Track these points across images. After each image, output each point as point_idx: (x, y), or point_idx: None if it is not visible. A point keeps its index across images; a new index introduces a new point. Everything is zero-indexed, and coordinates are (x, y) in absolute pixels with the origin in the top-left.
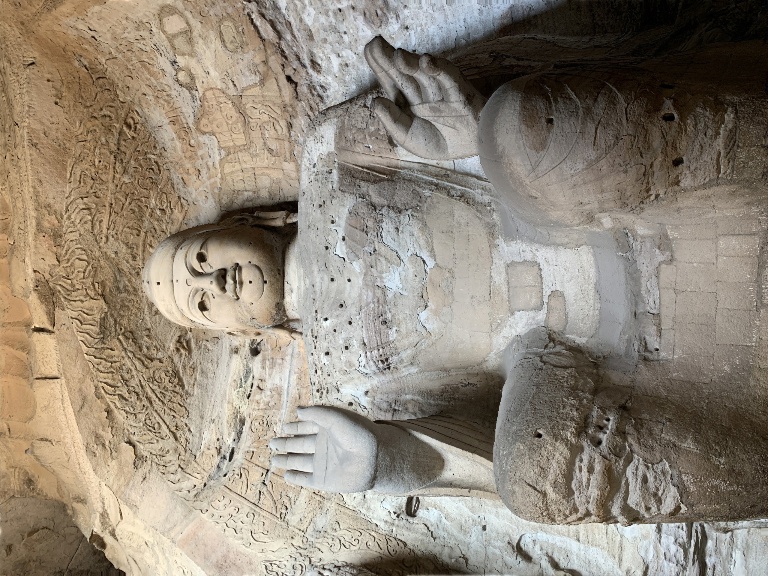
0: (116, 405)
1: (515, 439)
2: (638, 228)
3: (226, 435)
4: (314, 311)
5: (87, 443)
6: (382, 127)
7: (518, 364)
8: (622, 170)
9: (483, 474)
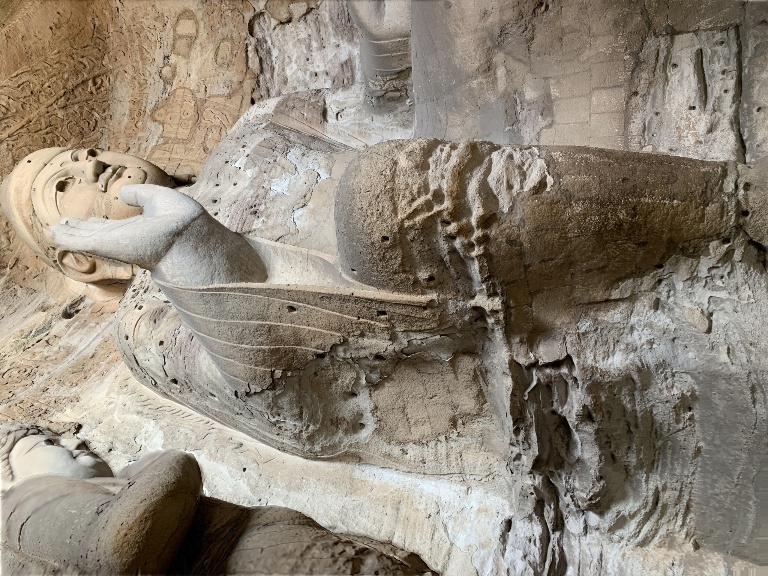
0: None
1: None
2: (526, 90)
3: None
4: None
5: None
6: (322, 100)
7: None
8: None
9: (311, 280)
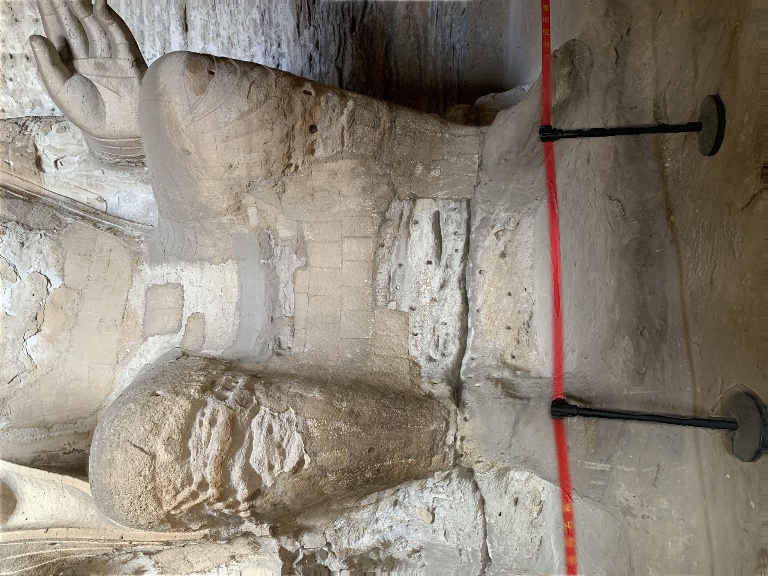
0: None
1: (126, 402)
2: (279, 228)
3: None
4: None
5: None
6: (31, 145)
7: None
8: (269, 127)
9: (72, 509)
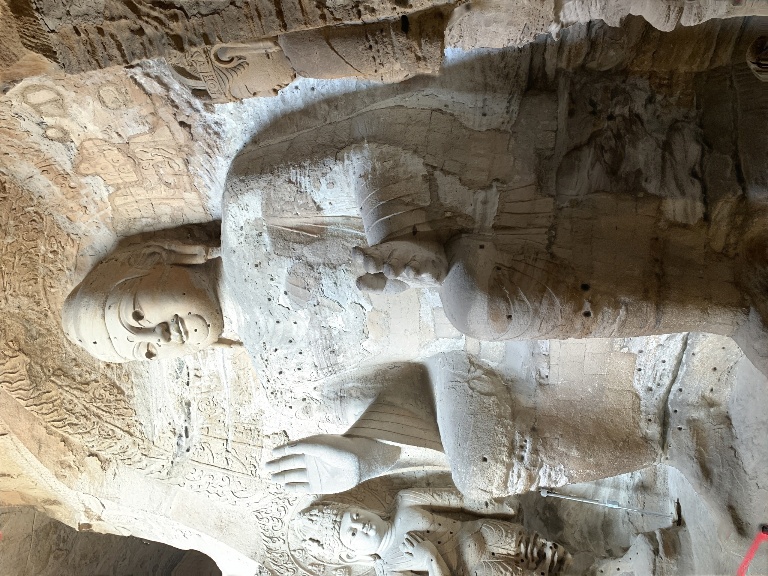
0: (69, 432)
1: (469, 463)
2: None
3: (176, 419)
4: (262, 343)
5: (55, 472)
6: (311, 201)
7: (451, 386)
8: (553, 337)
9: (431, 454)
